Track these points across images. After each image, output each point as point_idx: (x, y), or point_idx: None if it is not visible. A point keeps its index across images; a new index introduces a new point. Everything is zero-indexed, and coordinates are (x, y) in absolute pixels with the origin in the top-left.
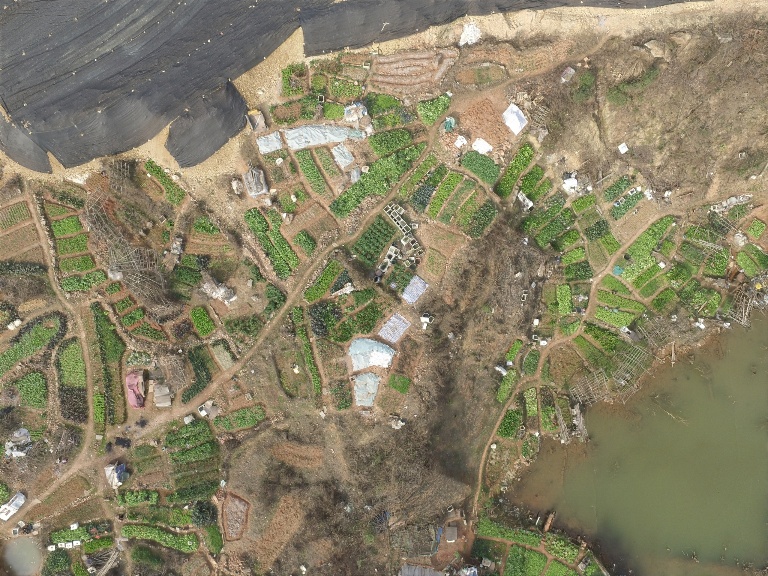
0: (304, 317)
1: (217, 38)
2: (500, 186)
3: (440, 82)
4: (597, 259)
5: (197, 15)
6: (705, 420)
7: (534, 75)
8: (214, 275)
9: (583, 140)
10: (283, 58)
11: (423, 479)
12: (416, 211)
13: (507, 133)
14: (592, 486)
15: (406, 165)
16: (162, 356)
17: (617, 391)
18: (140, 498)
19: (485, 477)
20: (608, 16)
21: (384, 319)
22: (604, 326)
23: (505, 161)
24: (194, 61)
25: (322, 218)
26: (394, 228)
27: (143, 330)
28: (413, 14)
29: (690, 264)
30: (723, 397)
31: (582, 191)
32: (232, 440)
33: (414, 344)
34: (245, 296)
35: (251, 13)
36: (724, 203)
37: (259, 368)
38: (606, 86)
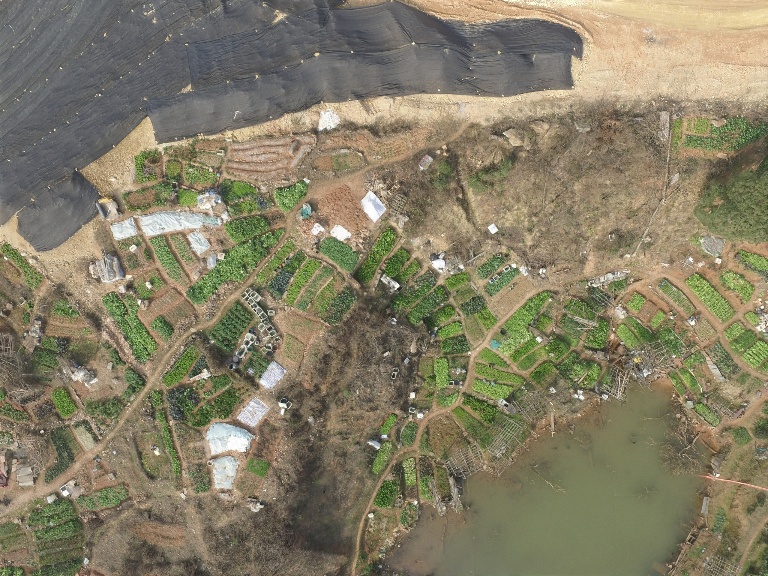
0: (164, 400)
1: (63, 127)
2: (361, 271)
3: (297, 169)
4: (474, 333)
5: (43, 103)
6: (584, 489)
7: (393, 162)
8: (74, 357)
9: (448, 223)
10: (134, 145)
11: (286, 557)
12: (274, 297)
13: (365, 220)
14: (471, 552)
15: (262, 252)
16: (24, 436)
17: (493, 463)
18: (4, 575)
19: (364, 544)
20: (467, 103)
21: (243, 403)
22: (483, 398)
23: (365, 247)
24: (40, 150)
25: (179, 304)
26: (252, 314)
27: (5, 411)
28: (264, 103)
29: (570, 337)
30: (602, 466)
31: (454, 270)
32: (95, 519)
33: (273, 428)
34: (106, 378)
35: (97, 102)
36: (602, 279)
37: (121, 449)
38: (467, 172)
